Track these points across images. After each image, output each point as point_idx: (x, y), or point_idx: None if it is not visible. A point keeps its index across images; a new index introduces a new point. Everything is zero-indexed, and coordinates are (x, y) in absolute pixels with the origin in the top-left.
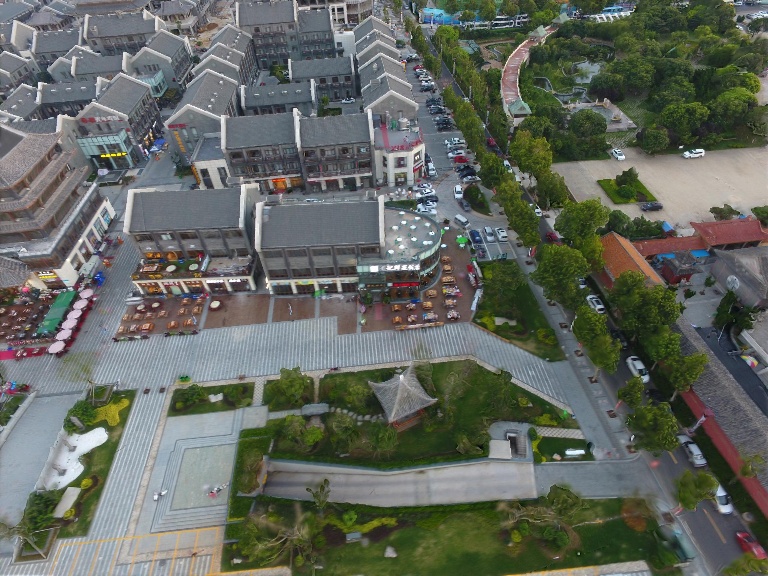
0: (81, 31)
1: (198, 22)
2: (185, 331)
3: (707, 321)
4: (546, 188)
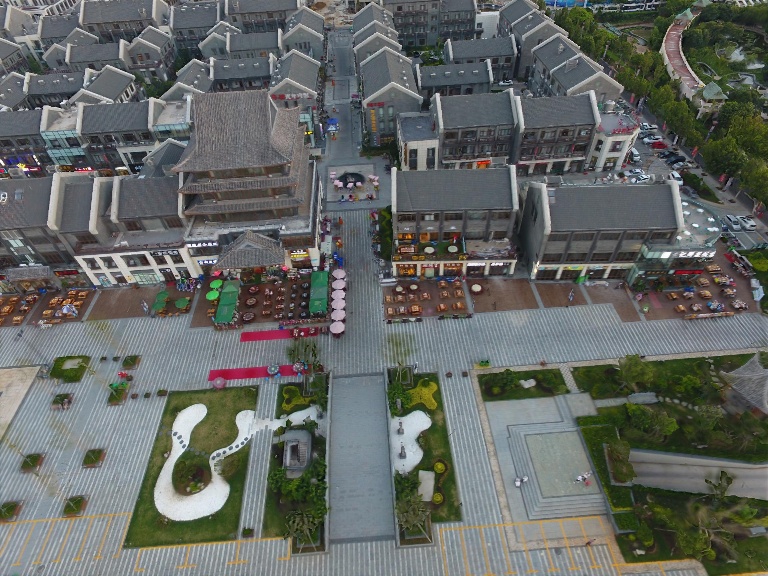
0: (219, 7)
1: (307, 1)
2: None
3: None
4: None
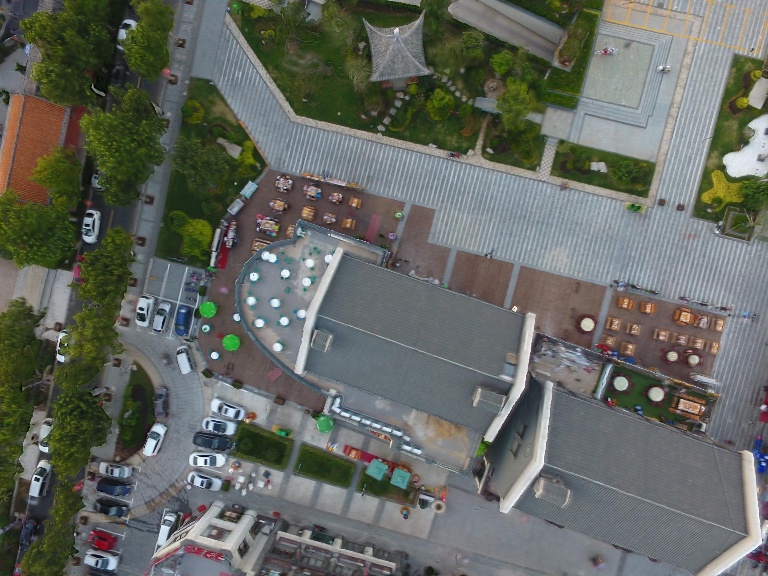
0: None
1: None
2: (631, 292)
3: (6, 66)
4: (26, 332)
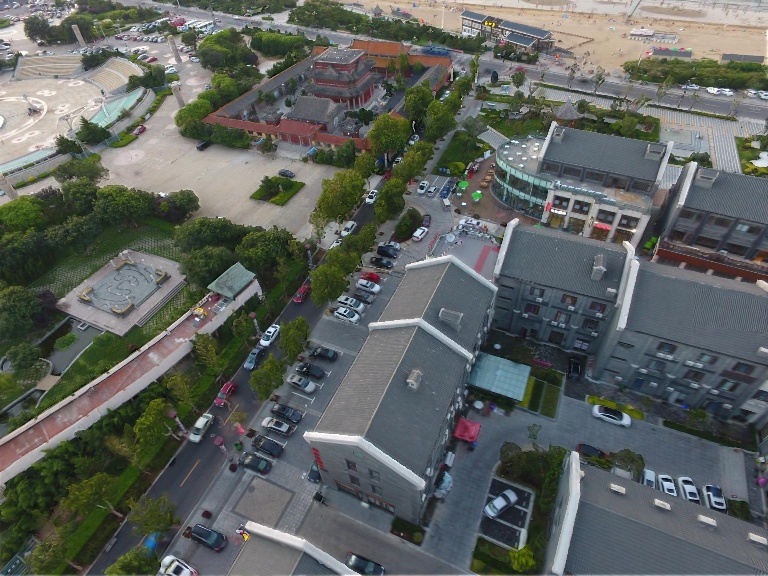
0: None
1: None
2: None
3: None
4: None
